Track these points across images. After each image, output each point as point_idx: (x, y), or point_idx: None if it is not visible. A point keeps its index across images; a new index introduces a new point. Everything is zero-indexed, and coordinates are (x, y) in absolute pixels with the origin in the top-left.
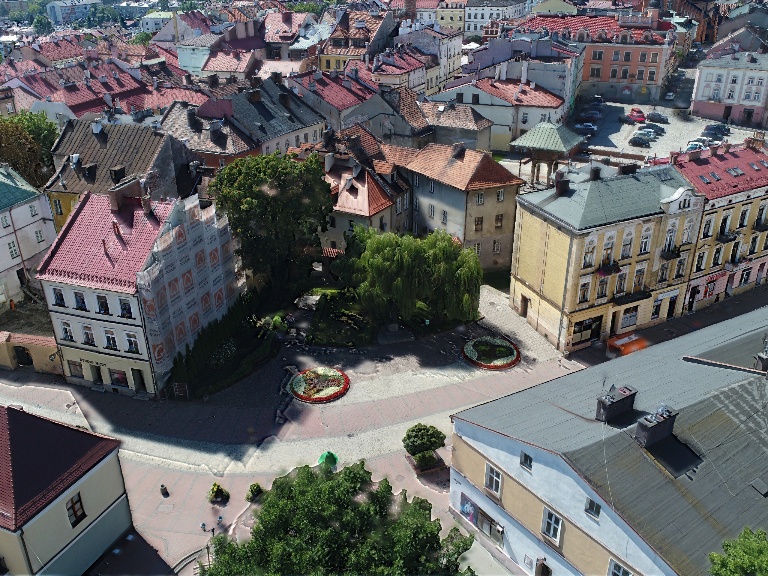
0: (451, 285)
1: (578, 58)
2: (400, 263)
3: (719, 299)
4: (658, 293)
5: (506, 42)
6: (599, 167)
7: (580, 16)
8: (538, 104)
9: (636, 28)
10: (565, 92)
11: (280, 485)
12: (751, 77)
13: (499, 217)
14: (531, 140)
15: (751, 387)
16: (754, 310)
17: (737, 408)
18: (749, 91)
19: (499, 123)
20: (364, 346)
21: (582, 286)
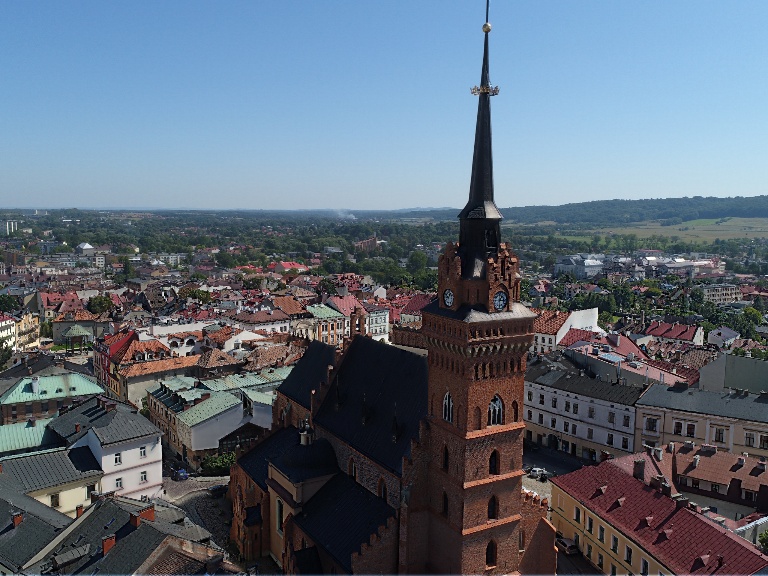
0: None
1: None
2: None
3: None
4: None
5: None
6: None
7: (183, 324)
8: None
9: None
10: None
11: None
12: None
13: None
14: None
15: None
16: None
17: None
18: None
19: None
20: None
21: None
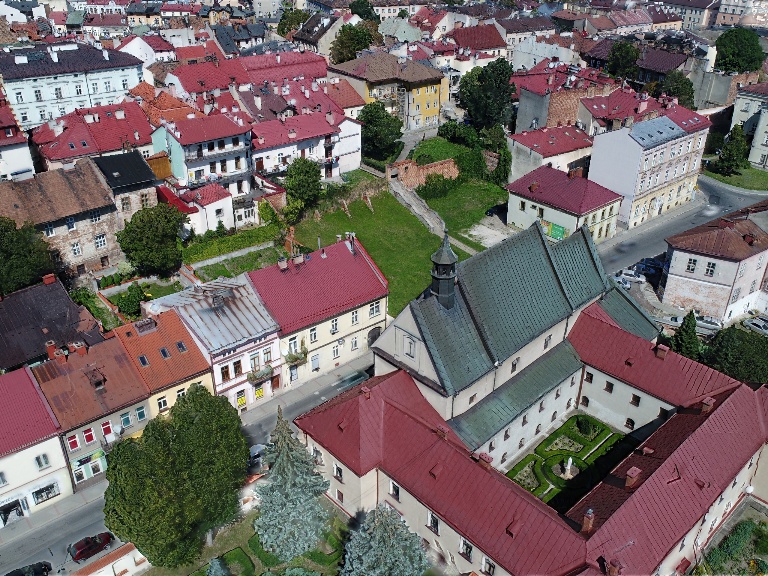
0: None
1: None
2: None
3: None
4: None
5: None
6: None
7: None
8: None
9: None
10: None
11: (364, 3)
12: None
13: None
14: None
15: (282, 12)
16: None
17: None
18: None
19: None
20: None
21: None
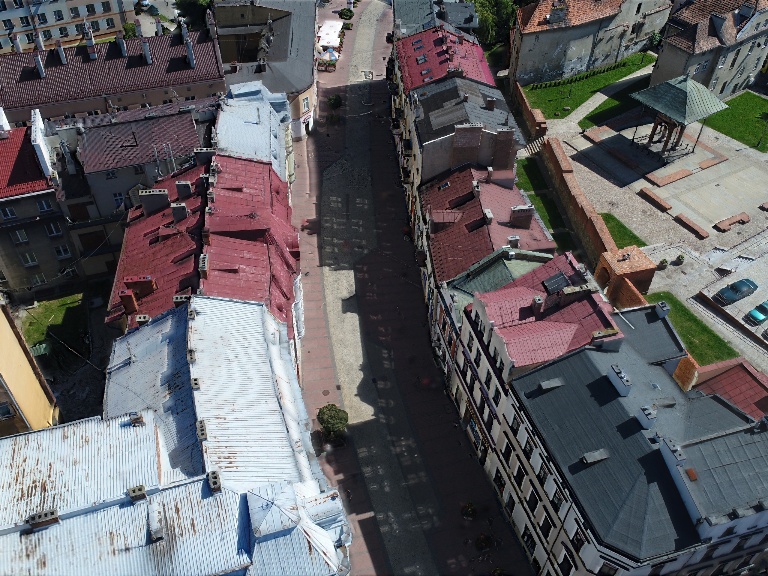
0: None
1: None
2: None
3: None
4: None
5: None
6: None
7: None
8: None
9: None
10: None
11: None
12: None
13: None
14: None
15: (255, 3)
16: None
17: None
18: None
19: None
20: None
21: None
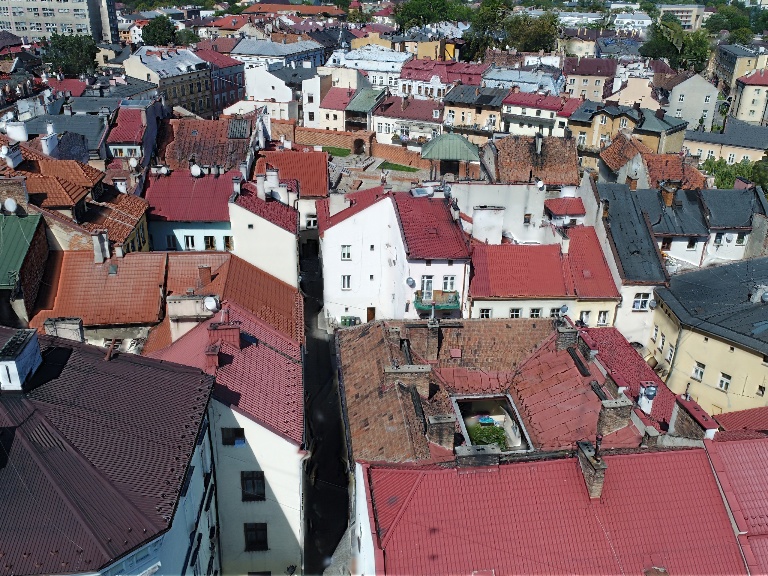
0: None
1: None
2: None
3: None
4: None
5: None
6: None
7: None
8: None
9: None
10: None
11: None
12: None
13: None
14: None
15: None
16: None
17: None
18: None
19: None
20: None
21: None
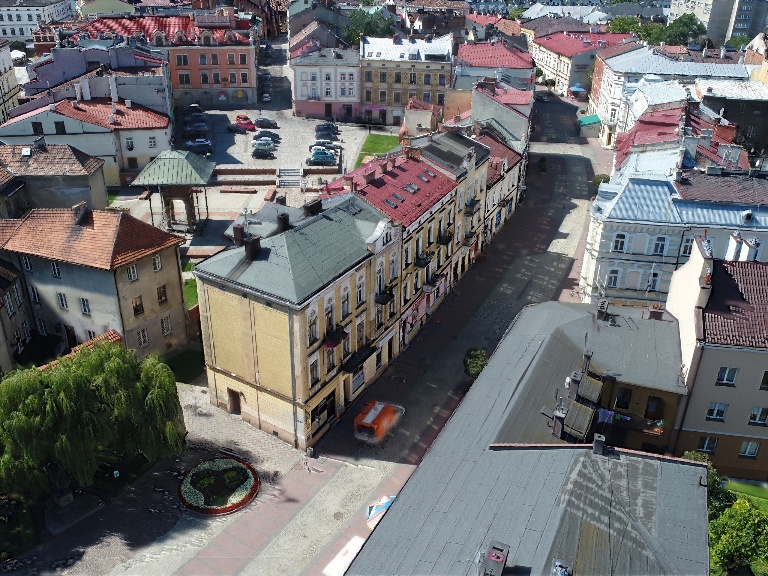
0: (139, 414)
1: (167, 66)
2: (57, 413)
3: (423, 323)
4: (378, 341)
5: (76, 52)
6: (285, 213)
7: (150, 17)
8: (142, 126)
9: (215, 28)
10: (167, 107)
11: None
12: (342, 73)
13: (161, 290)
14: (158, 176)
15: (588, 471)
16: (499, 346)
17: (594, 508)
18: (343, 87)
19: (99, 154)
20: (28, 549)
21: (310, 366)
